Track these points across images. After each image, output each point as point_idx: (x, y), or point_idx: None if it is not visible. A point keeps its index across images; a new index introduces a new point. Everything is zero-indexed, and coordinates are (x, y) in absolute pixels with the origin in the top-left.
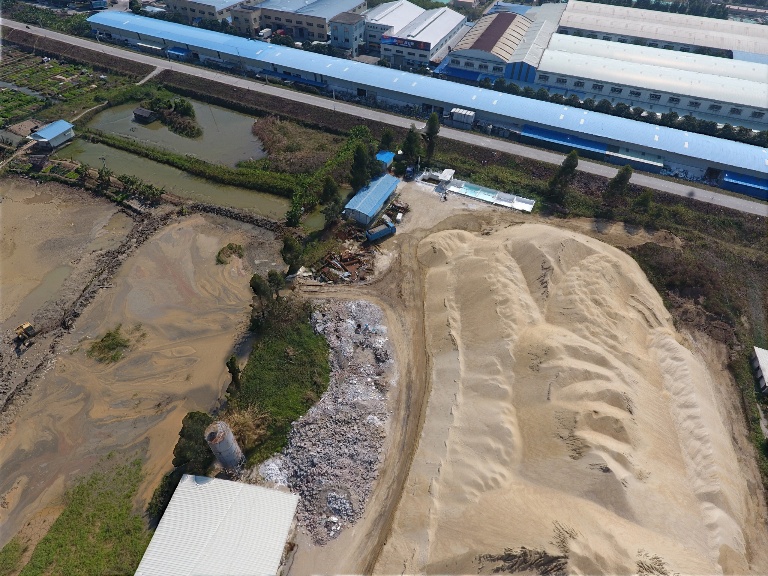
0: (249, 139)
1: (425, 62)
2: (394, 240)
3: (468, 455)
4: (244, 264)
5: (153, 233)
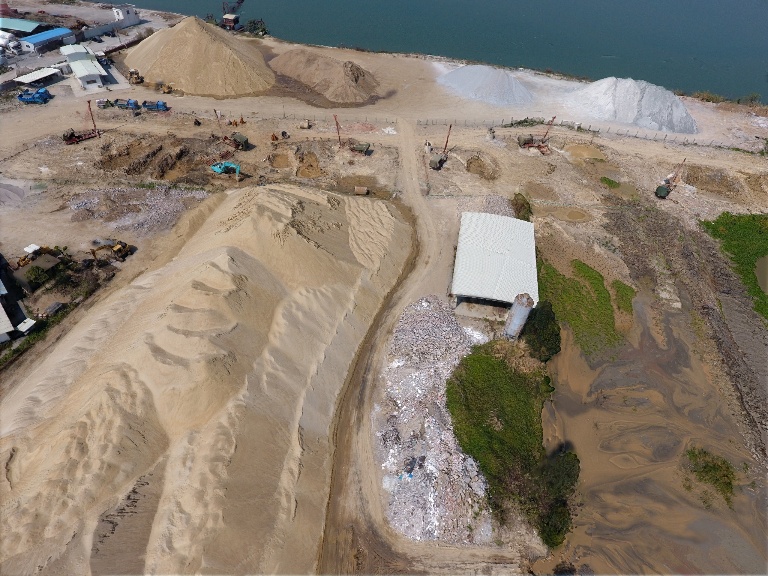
0: None
1: None
2: None
3: (321, 317)
4: None
5: None
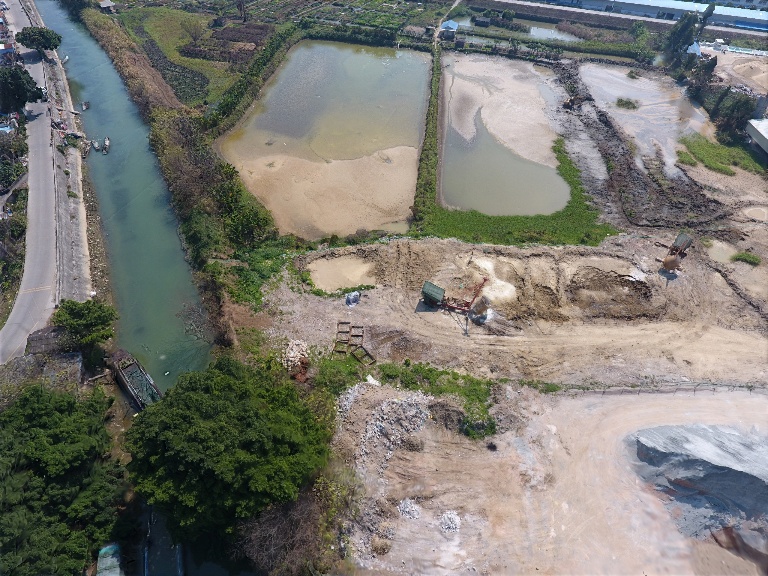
0: (553, 36)
1: None
2: (718, 68)
3: None
4: (647, 79)
5: (578, 69)
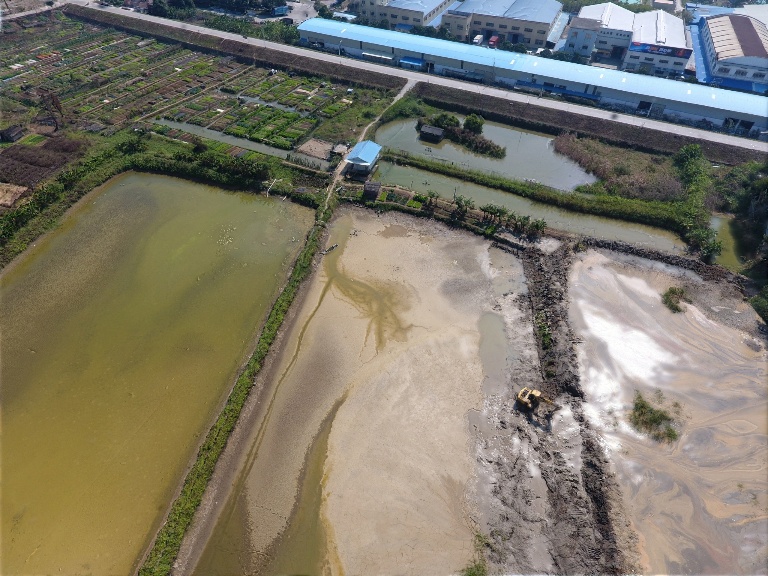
0: (547, 158)
1: (679, 70)
2: None
3: None
4: (703, 312)
5: (567, 274)
